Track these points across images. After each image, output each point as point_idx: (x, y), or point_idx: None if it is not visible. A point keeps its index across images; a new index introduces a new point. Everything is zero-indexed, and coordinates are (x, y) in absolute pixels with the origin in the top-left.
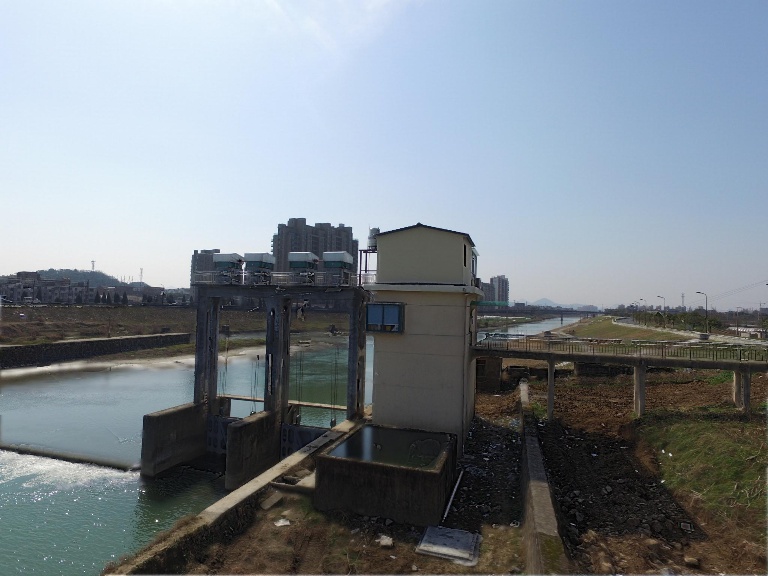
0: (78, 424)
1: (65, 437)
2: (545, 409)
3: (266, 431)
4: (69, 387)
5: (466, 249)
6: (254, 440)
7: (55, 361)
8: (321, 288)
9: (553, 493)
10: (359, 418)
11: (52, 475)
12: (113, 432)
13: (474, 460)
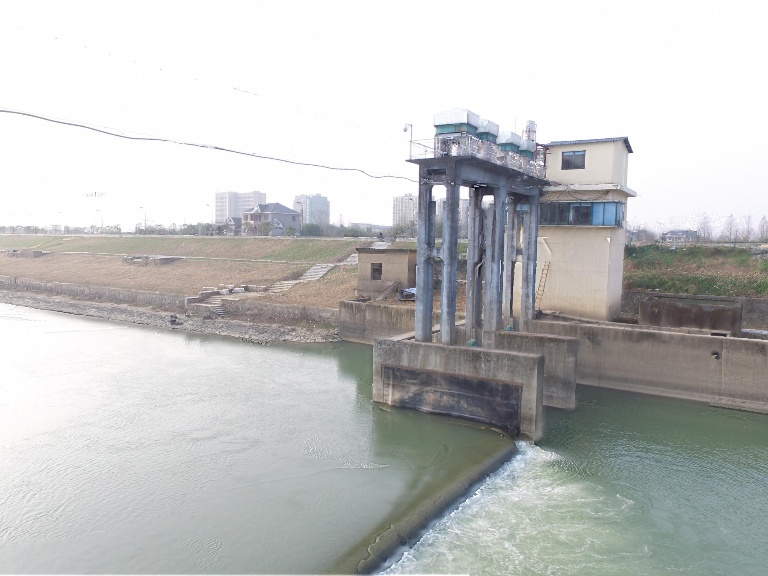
0: (151, 526)
1: (292, 521)
2: None
3: None
4: None
5: None
6: None
7: None
8: (537, 181)
9: None
10: (545, 315)
11: (543, 500)
12: (284, 477)
13: None
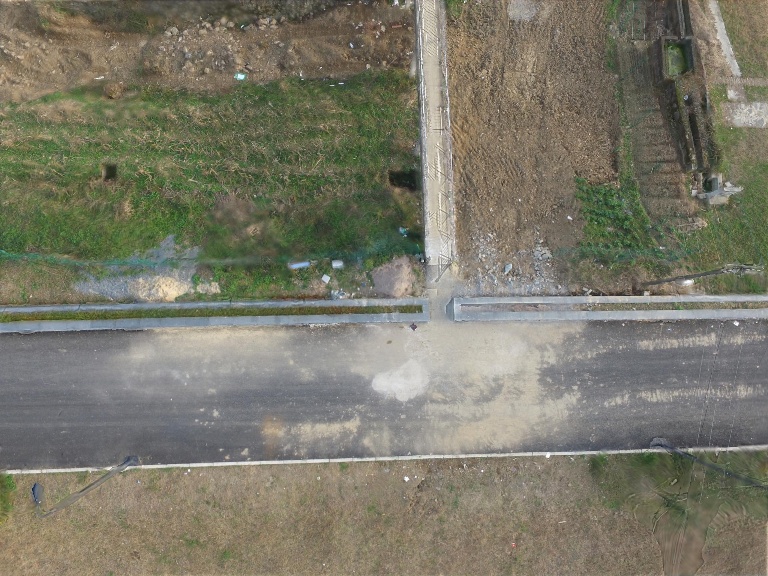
0: None
1: None
2: (448, 5)
3: None
4: None
5: None
6: None
7: None
8: None
9: (226, 1)
10: None
11: None
12: None
13: None
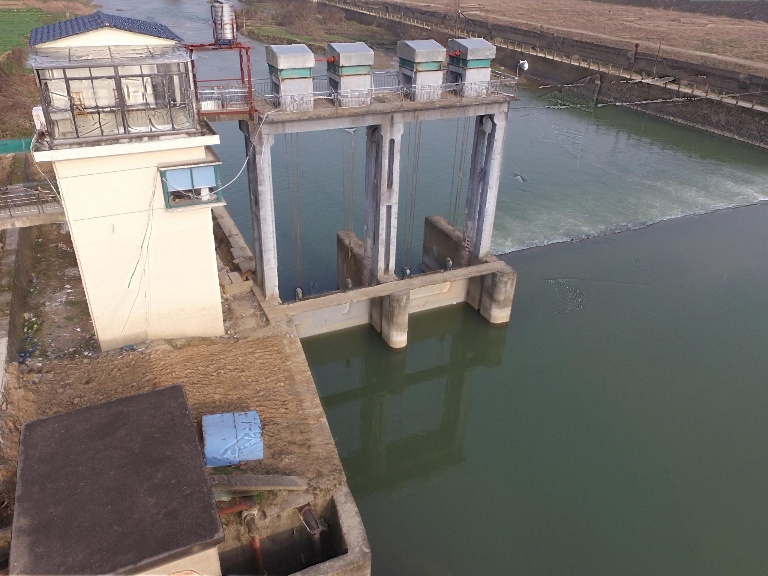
0: (668, 275)
1: (605, 261)
2: None
3: None
4: None
5: None
6: (345, 263)
7: None
8: None
9: None
10: None
11: None
12: (603, 282)
13: None
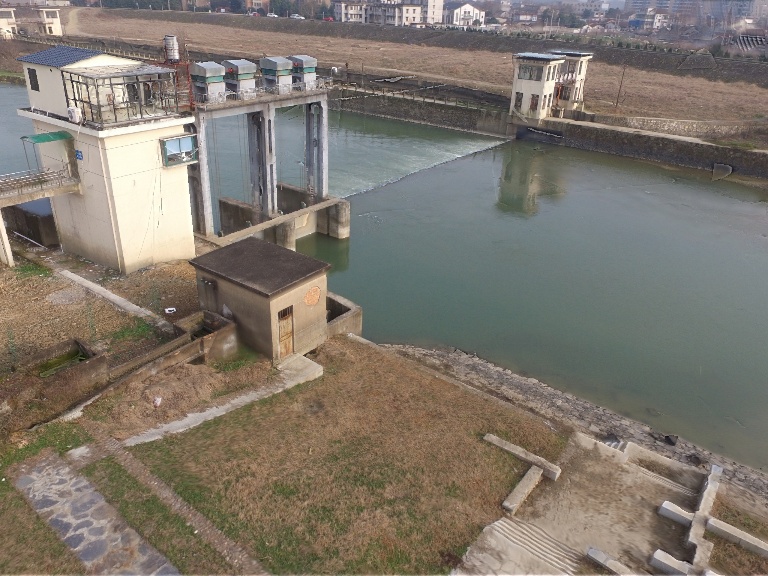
0: (425, 202)
1: (386, 201)
2: None
3: (243, 220)
4: (591, 192)
5: (37, 72)
6: None
7: (743, 174)
8: None
9: None
10: None
11: None
12: (391, 211)
13: (50, 253)
